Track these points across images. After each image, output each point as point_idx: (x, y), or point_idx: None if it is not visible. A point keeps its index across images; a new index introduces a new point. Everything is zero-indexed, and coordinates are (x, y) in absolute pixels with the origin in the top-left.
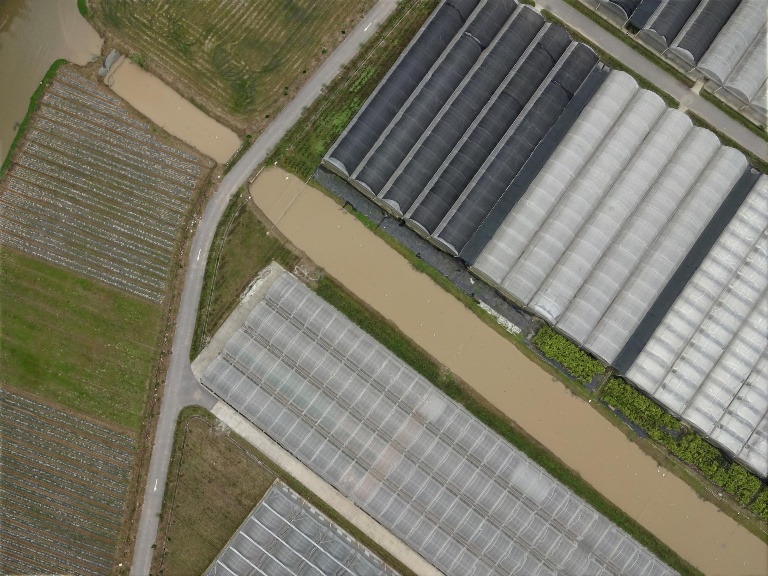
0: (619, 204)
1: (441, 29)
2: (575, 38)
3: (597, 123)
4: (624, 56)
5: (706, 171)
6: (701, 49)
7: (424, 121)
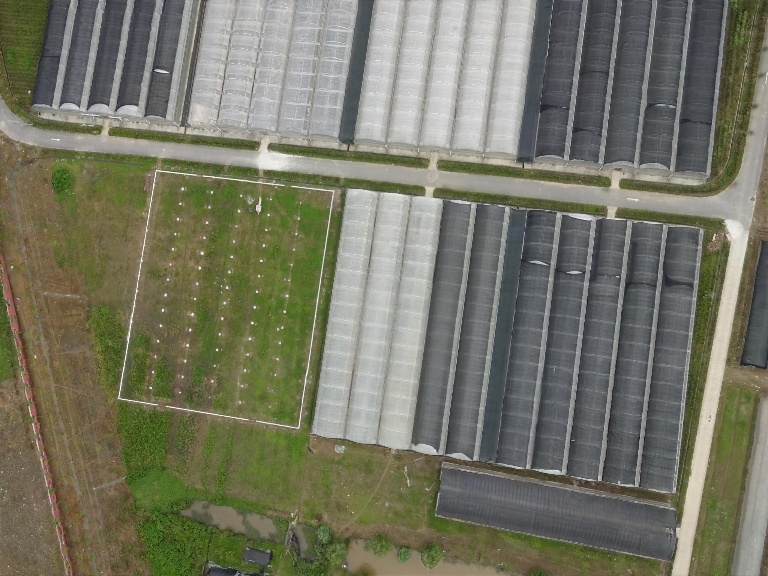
0: (451, 35)
1: (700, 97)
2: (565, 176)
3: (508, 93)
4: (510, 185)
5: (388, 111)
6: (448, 215)
7: (664, 9)
